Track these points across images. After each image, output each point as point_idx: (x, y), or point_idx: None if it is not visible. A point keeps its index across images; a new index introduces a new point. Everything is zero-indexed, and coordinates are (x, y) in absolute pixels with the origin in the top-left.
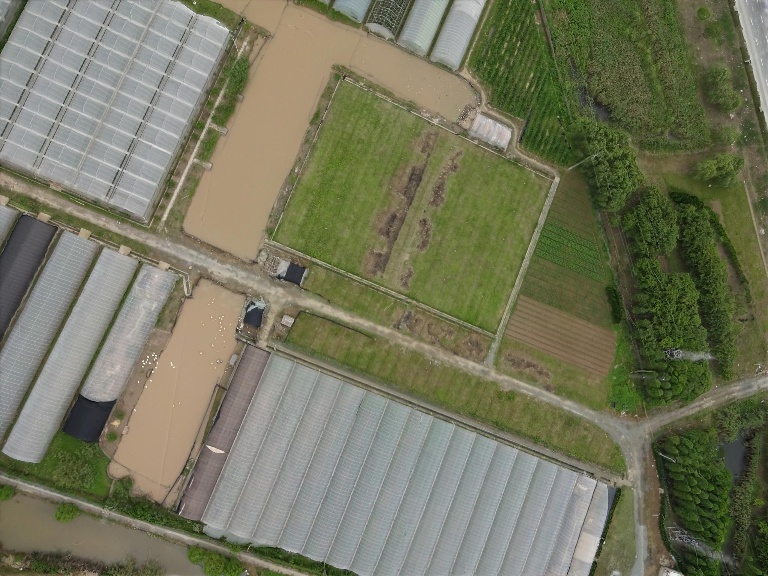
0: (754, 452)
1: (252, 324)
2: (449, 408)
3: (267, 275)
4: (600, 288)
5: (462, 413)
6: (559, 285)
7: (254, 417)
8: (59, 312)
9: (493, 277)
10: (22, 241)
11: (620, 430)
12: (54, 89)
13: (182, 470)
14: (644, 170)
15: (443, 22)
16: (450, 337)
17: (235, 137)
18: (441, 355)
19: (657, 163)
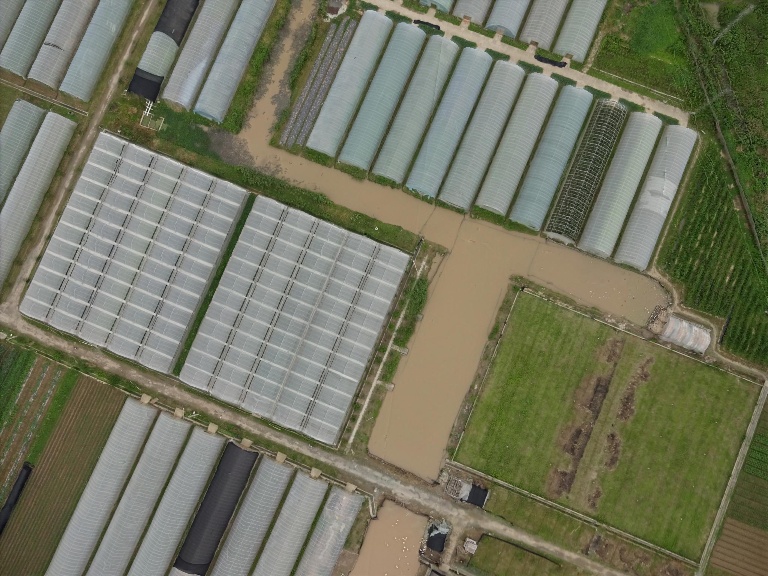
0: None
1: (435, 550)
2: None
3: (449, 496)
4: None
5: None
6: None
7: None
8: (260, 535)
9: (693, 497)
10: (230, 470)
11: None
12: (256, 329)
13: None
14: None
15: (627, 220)
16: (645, 565)
17: (415, 355)
18: None
19: None
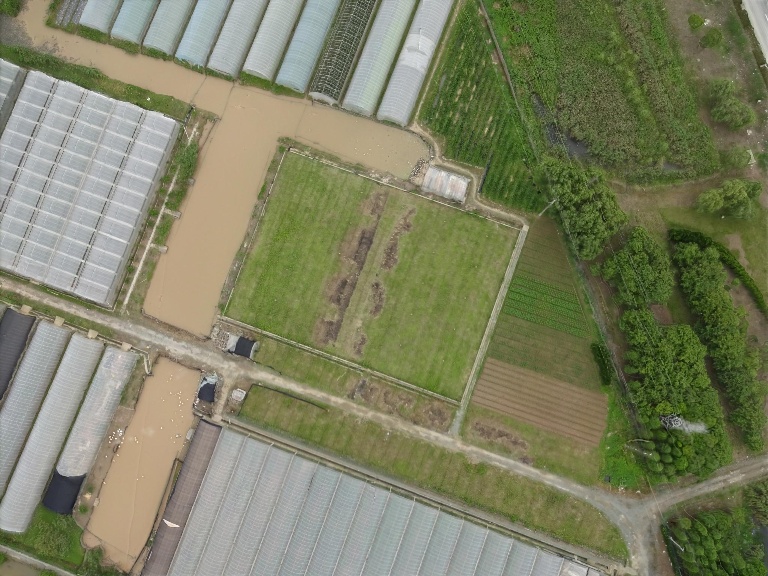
0: None
1: (204, 399)
2: (410, 482)
3: (220, 350)
4: (584, 345)
5: (425, 488)
6: (533, 344)
7: (206, 492)
8: (37, 394)
9: (455, 339)
10: (5, 332)
11: (618, 508)
12: (27, 196)
13: (146, 541)
14: (634, 207)
15: (389, 79)
16: (409, 406)
17: (189, 219)
18: (400, 425)
19: (651, 197)
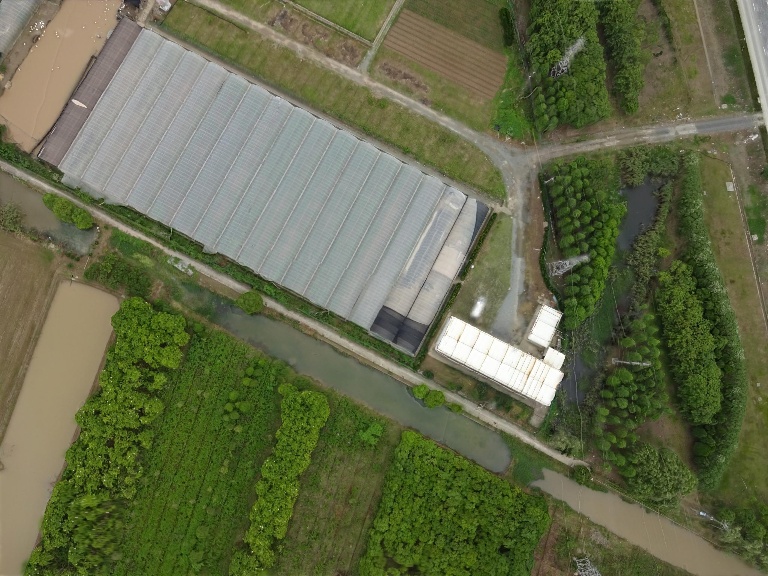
0: (664, 200)
1: (130, 1)
2: (315, 106)
3: None
4: (493, 11)
5: (328, 113)
6: (447, 3)
7: (118, 79)
8: None
9: None
10: None
11: (503, 155)
12: None
13: (52, 126)
14: None
15: None
16: (324, 40)
17: None
18: (313, 55)
19: None
